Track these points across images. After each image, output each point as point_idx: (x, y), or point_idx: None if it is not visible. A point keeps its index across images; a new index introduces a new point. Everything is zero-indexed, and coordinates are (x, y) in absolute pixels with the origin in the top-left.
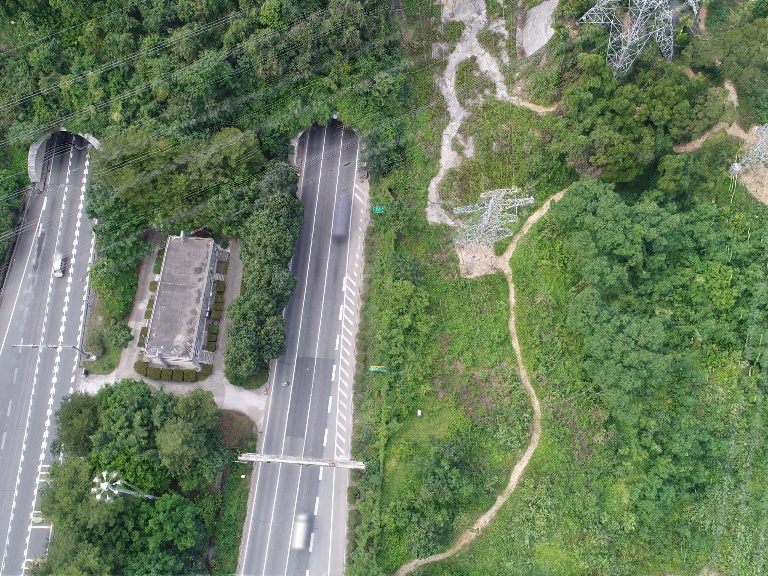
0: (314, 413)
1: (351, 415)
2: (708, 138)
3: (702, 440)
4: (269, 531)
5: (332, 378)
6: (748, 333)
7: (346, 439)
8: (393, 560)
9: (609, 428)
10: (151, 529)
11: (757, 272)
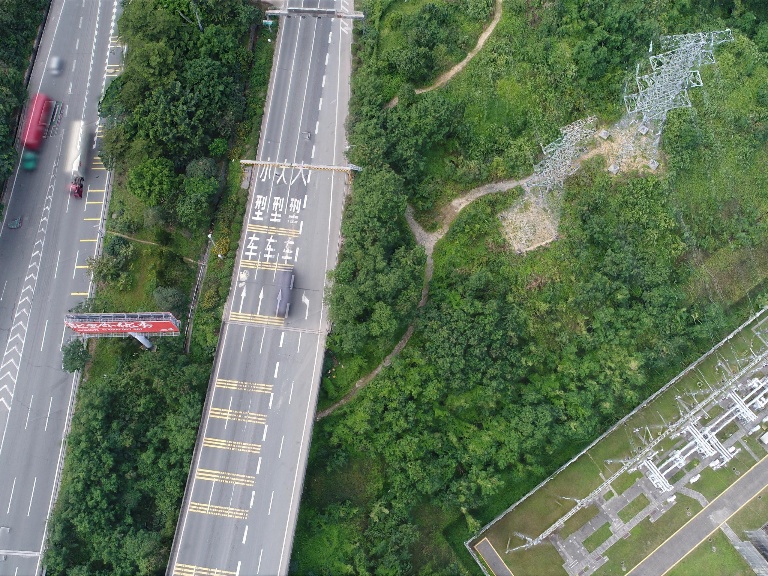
0: (323, 1)
1: (353, 1)
2: None
3: (630, 21)
4: (291, 75)
5: None
6: None
7: None
8: (387, 92)
9: None
10: (202, 44)
11: None
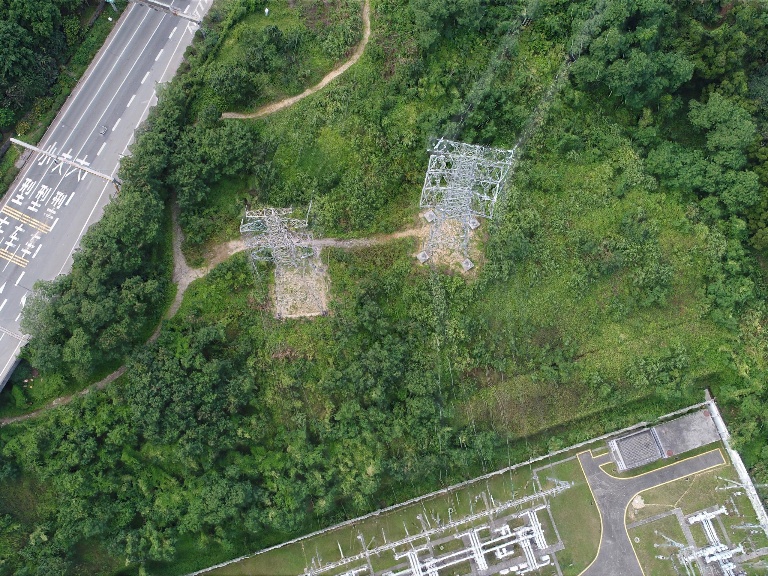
0: None
1: None
2: None
3: (500, 101)
4: (116, 62)
5: None
6: (571, 24)
7: (201, 16)
8: None
9: None
10: (15, 6)
11: None
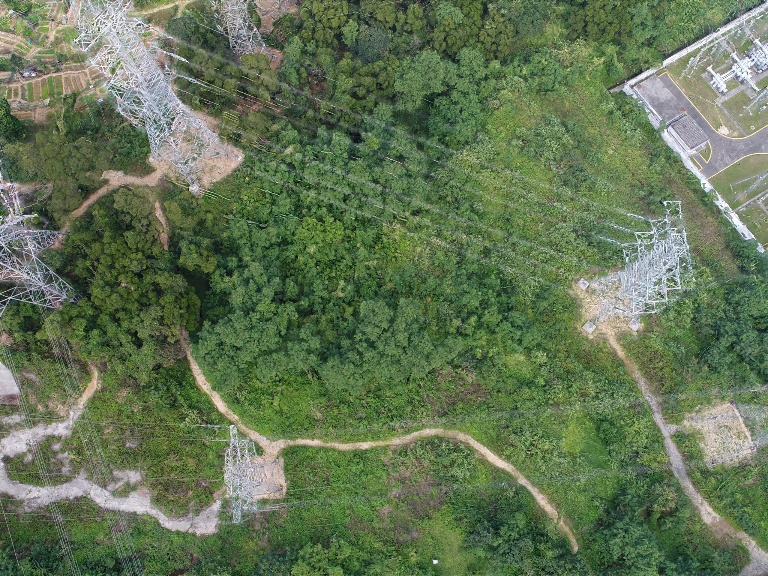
0: None
1: None
2: (174, 220)
3: None
4: None
5: None
6: None
7: None
8: None
9: (457, 364)
10: None
11: (310, 195)
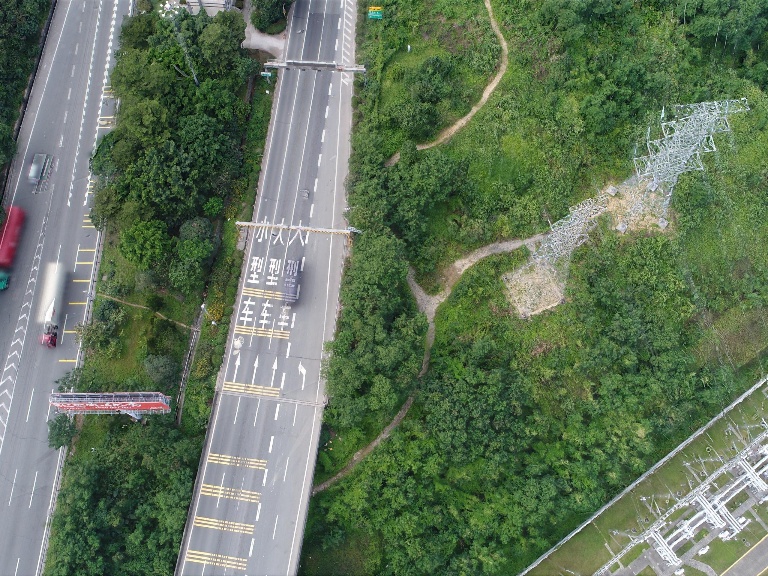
0: (324, 51)
1: (354, 51)
2: None
3: (639, 73)
4: (289, 129)
5: (338, 27)
6: None
7: None
8: (389, 148)
9: None
10: (197, 100)
11: None
